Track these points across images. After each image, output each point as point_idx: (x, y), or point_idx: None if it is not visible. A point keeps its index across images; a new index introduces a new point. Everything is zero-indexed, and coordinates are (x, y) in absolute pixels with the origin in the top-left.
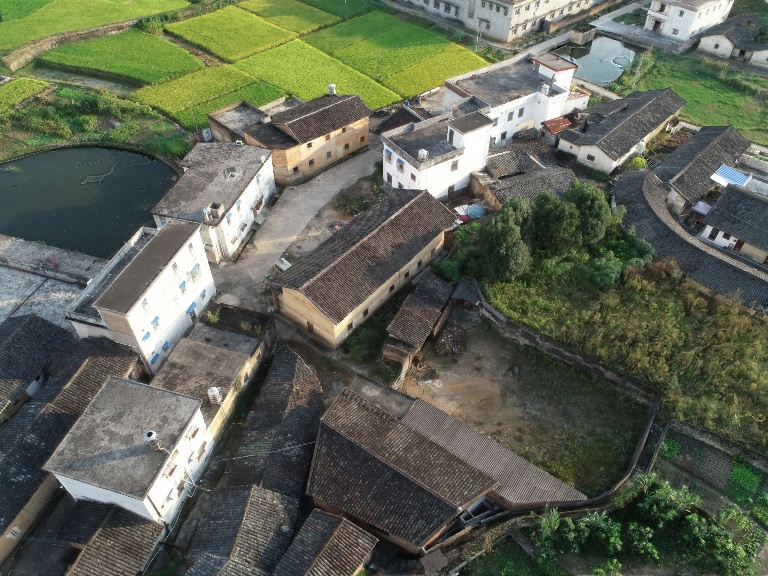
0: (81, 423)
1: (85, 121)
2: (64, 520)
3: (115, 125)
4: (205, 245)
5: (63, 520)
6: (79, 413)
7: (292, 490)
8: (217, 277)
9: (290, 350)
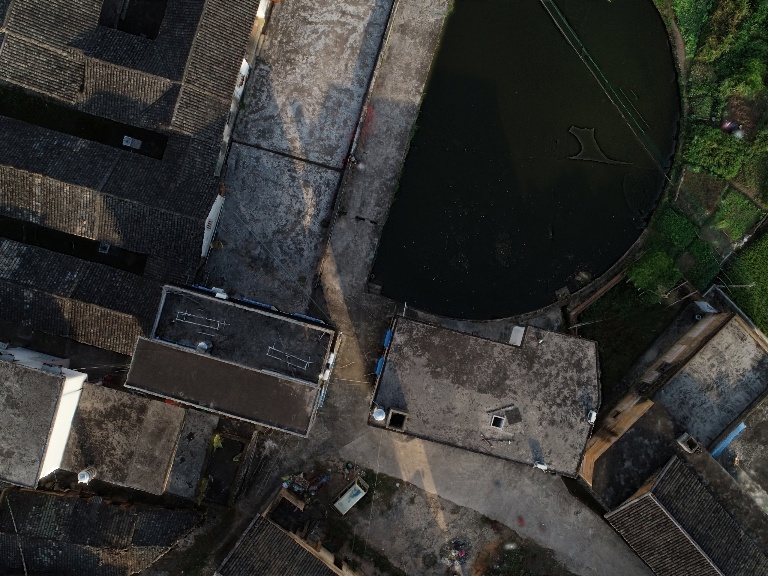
0: (3, 366)
1: (744, 74)
2: (3, 328)
3: (736, 131)
4: (374, 388)
5: (3, 327)
6: (74, 326)
7: (4, 560)
8: (347, 398)
9: (183, 534)
